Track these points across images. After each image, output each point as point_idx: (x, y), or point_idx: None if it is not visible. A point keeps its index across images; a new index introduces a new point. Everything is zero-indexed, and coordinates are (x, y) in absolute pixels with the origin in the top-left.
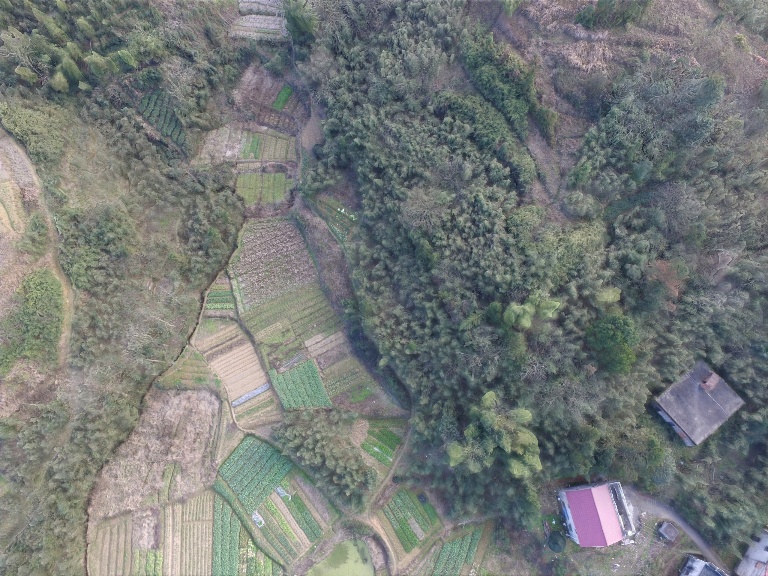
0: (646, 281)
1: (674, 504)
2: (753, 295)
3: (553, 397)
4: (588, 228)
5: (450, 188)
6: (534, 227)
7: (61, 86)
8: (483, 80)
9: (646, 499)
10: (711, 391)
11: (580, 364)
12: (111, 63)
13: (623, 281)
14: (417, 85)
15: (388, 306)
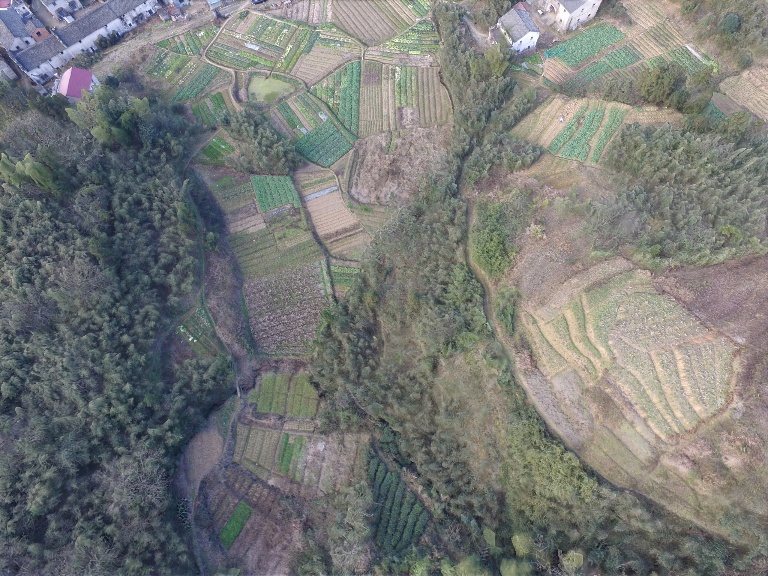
0: None
1: None
2: None
3: None
4: None
5: None
6: None
7: None
8: None
9: None
10: None
11: None
12: None
13: None
14: None
15: None
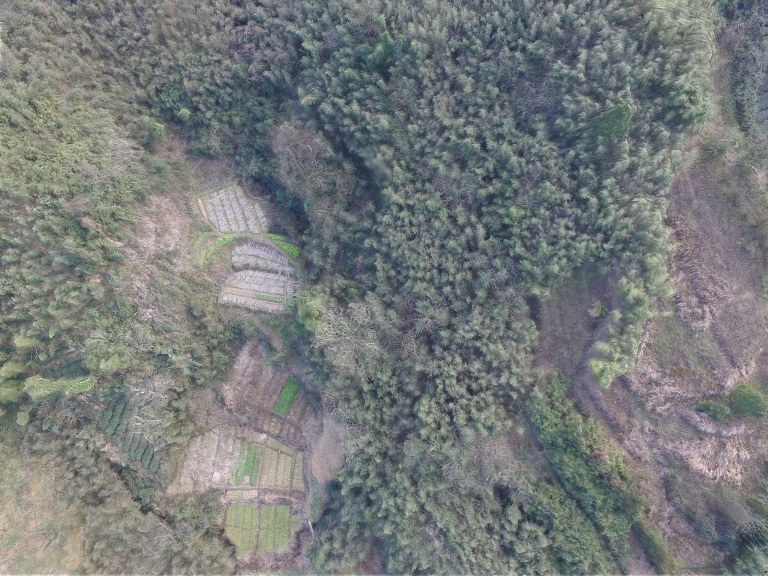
0: None
1: None
2: None
3: None
4: None
5: None
6: None
7: None
8: (565, 474)
9: None
10: None
11: None
12: (60, 389)
13: None
14: (471, 458)
15: None
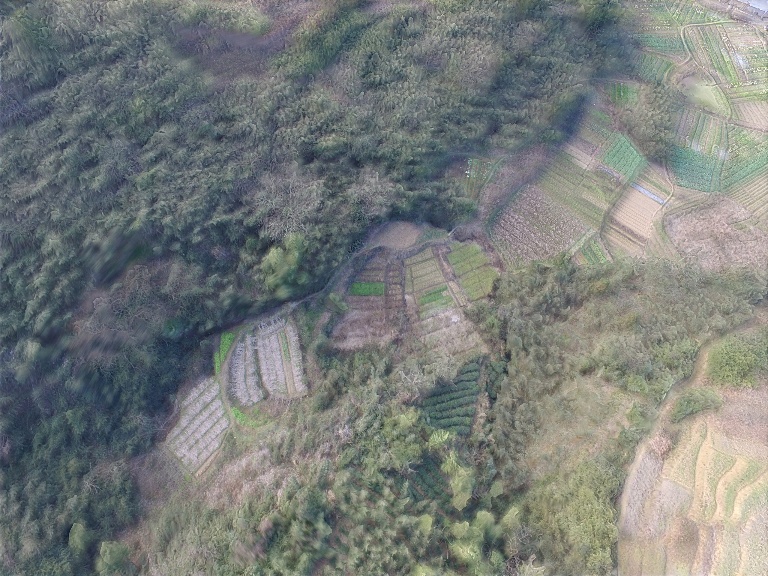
0: None
1: None
2: None
3: None
4: None
5: None
6: None
7: None
8: (328, 47)
9: None
10: None
11: None
12: None
13: None
14: None
15: None
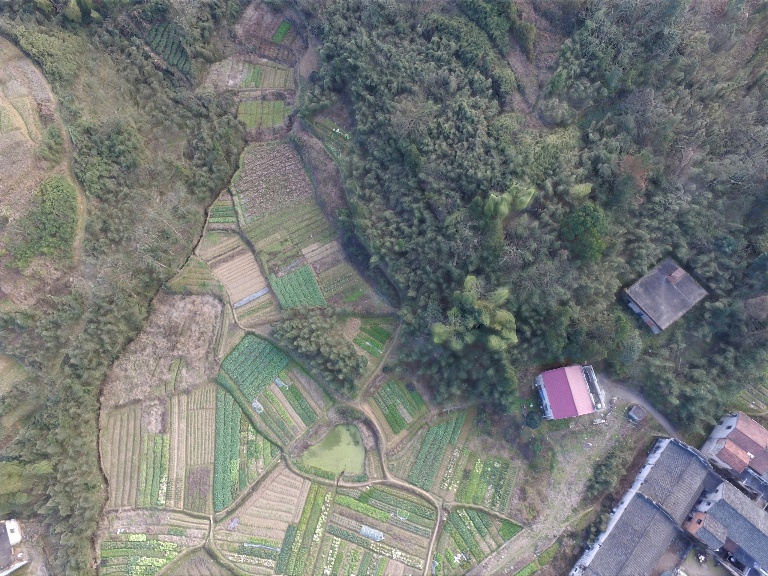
0: (616, 178)
1: (643, 390)
2: (716, 195)
3: (529, 281)
4: (563, 132)
5: (437, 103)
6: (513, 132)
7: (74, 14)
8: (468, 1)
9: (617, 386)
10: (677, 283)
11: (554, 253)
12: None
13: (595, 180)
14: (407, 8)
15: (379, 211)
